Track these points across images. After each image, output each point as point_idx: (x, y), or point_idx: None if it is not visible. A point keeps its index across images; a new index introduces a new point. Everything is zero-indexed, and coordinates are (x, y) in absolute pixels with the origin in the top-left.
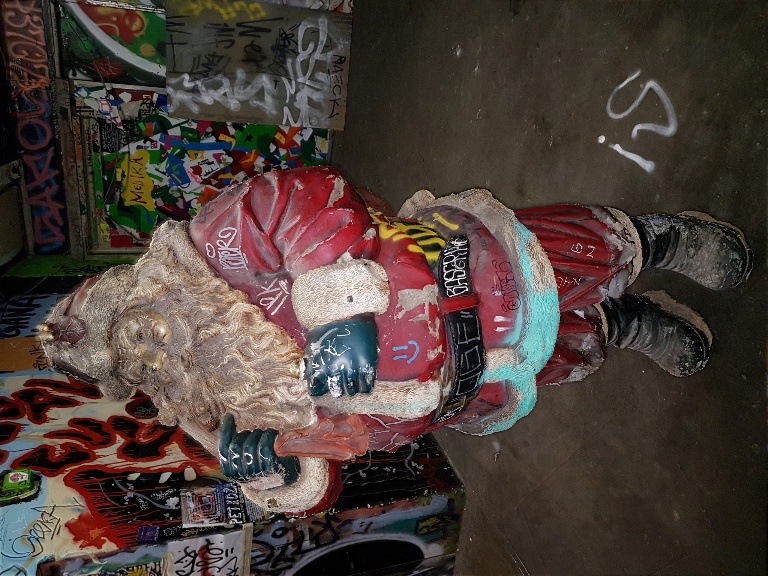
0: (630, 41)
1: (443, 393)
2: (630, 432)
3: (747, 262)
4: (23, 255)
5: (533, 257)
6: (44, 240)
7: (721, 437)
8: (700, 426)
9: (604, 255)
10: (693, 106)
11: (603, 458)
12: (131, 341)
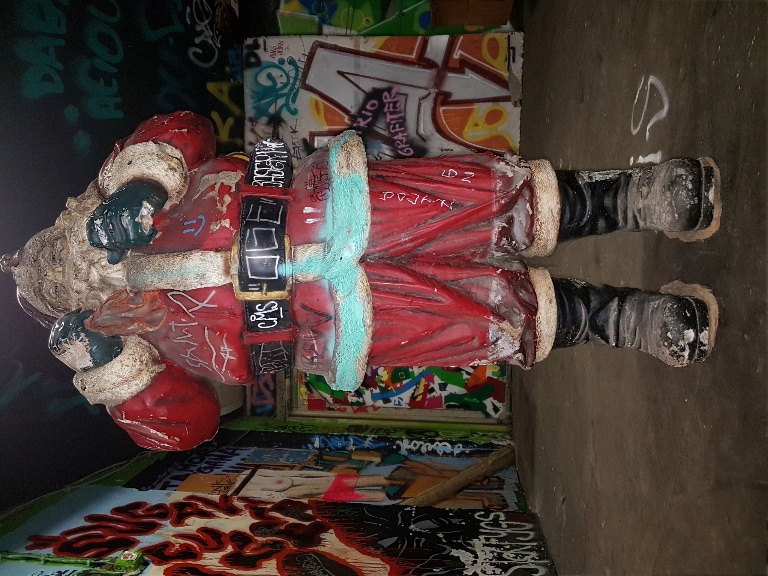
0: (636, 57)
1: (231, 271)
2: (688, 496)
3: (703, 178)
4: (240, 414)
5: (344, 150)
6: (258, 402)
7: (745, 442)
8: (730, 441)
9: (486, 181)
10: (674, 73)
11: (674, 553)
12: (45, 261)
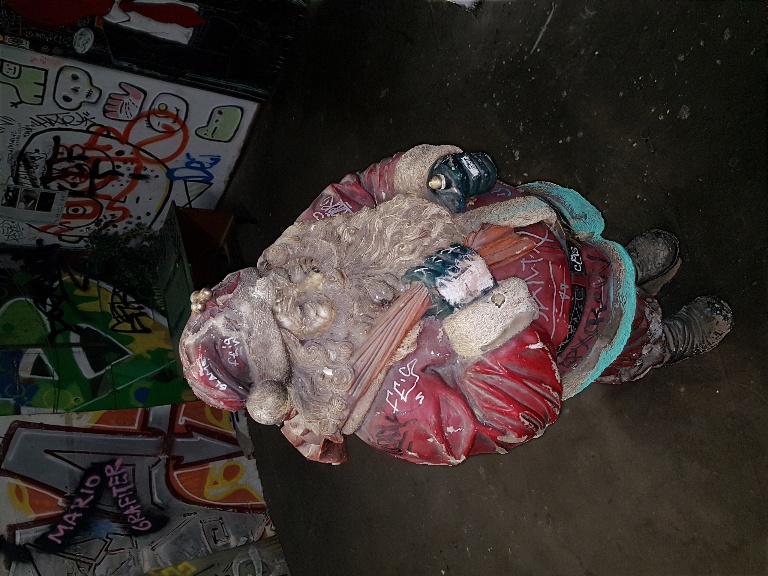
0: None
1: None
2: None
3: None
4: None
5: None
6: None
7: None
8: None
9: None
10: None
11: None
12: None
